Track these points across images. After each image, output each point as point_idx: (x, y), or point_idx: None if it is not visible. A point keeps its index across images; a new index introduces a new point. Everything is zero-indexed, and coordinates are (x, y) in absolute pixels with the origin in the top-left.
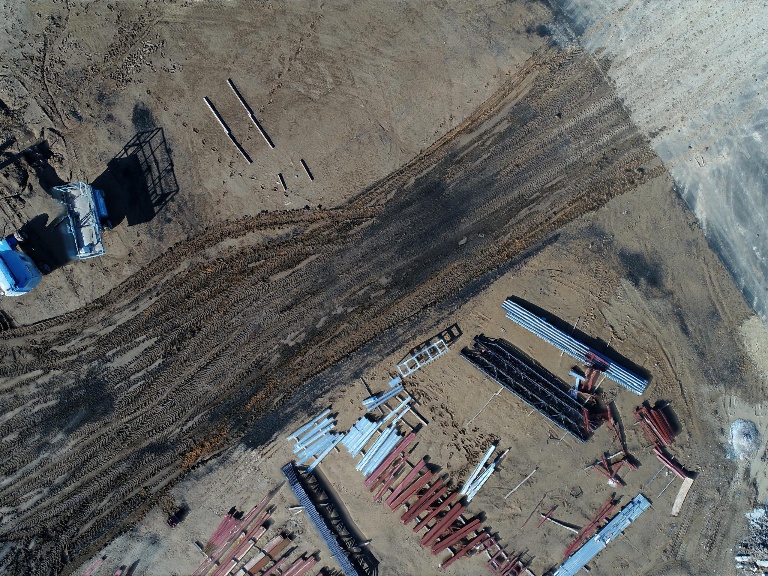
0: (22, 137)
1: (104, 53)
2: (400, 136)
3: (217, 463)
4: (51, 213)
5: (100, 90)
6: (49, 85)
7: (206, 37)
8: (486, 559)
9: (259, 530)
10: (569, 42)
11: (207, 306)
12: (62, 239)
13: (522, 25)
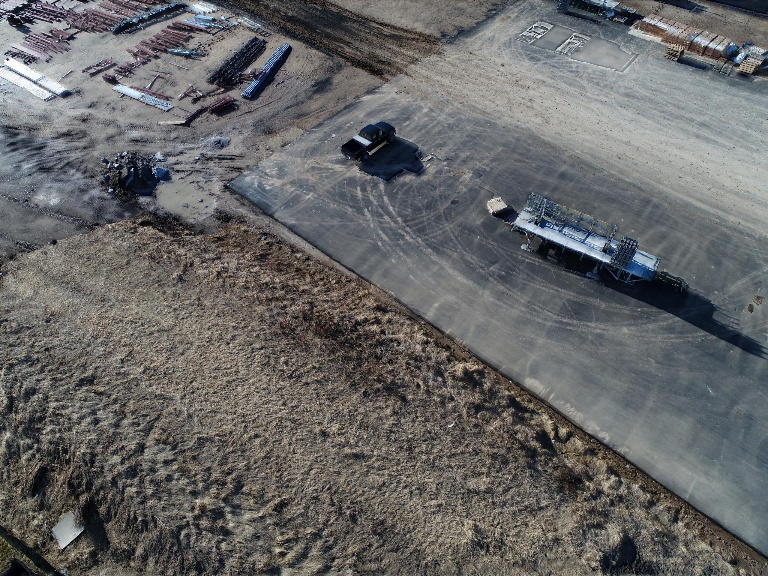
0: None
1: None
2: None
3: None
4: None
5: None
6: None
7: None
8: None
9: (151, 2)
10: None
11: None
12: None
13: None
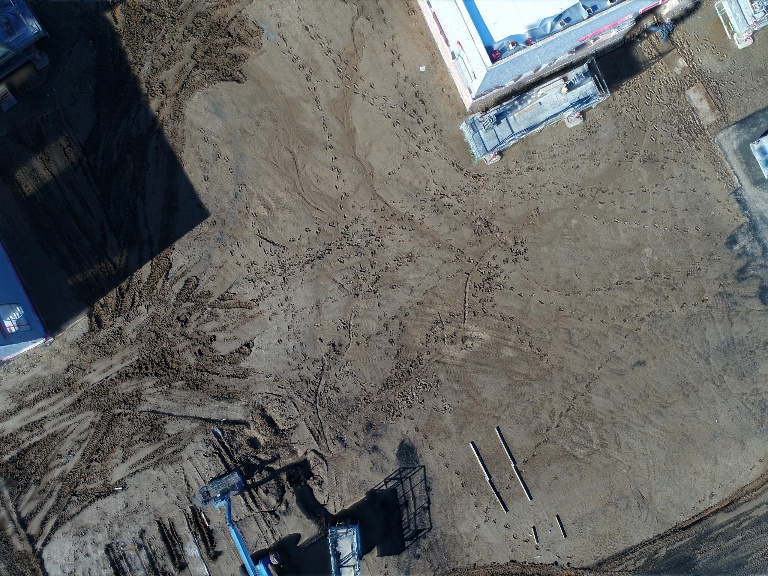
0: (286, 455)
1: (378, 385)
2: (658, 506)
3: None
4: (304, 533)
5: (369, 420)
6: (320, 409)
7: (481, 383)
8: None
9: None
10: None
11: None
12: (311, 560)
13: None
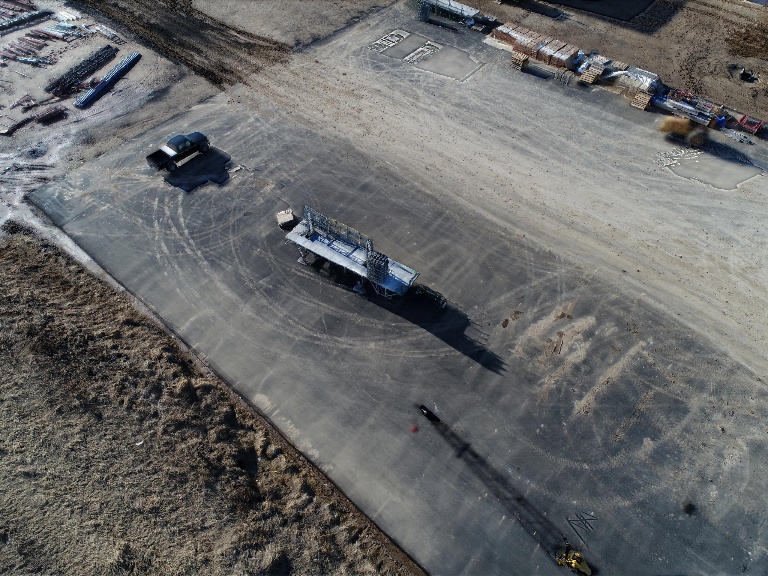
0: None
1: None
2: (231, 17)
3: None
4: None
5: None
6: None
7: None
8: None
9: (18, 9)
10: None
11: None
12: None
13: None
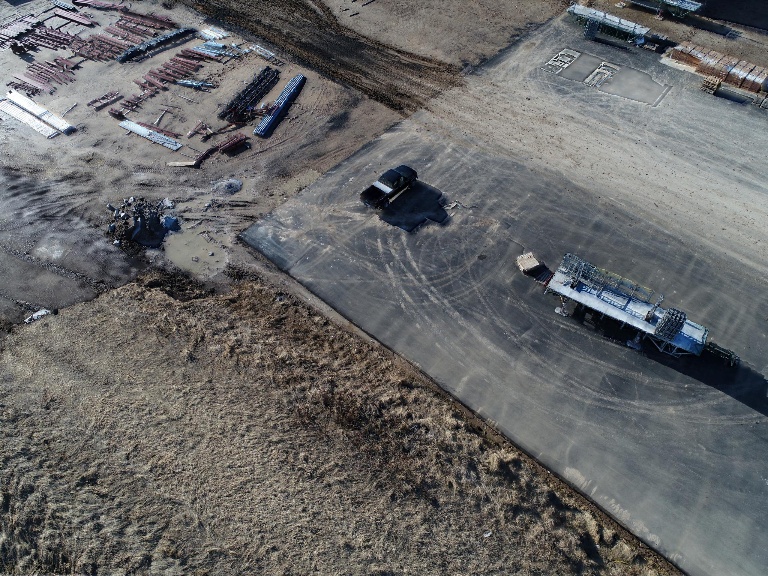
0: None
1: None
2: (384, 35)
3: (195, 13)
4: None
5: None
6: None
7: None
8: (138, 95)
9: (159, 27)
10: None
11: (276, 1)
12: None
13: None
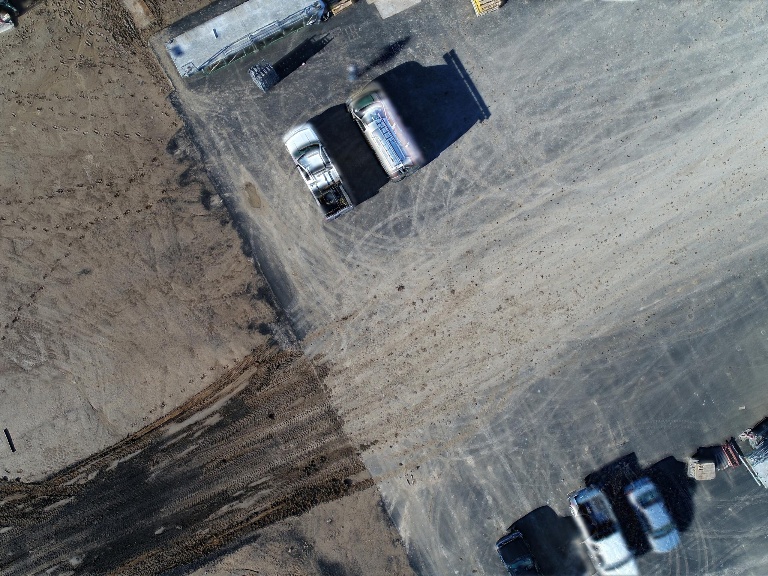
0: None
1: None
2: (109, 417)
3: None
4: None
5: None
6: None
7: None
8: None
9: None
10: (290, 344)
11: None
12: None
13: (245, 321)
